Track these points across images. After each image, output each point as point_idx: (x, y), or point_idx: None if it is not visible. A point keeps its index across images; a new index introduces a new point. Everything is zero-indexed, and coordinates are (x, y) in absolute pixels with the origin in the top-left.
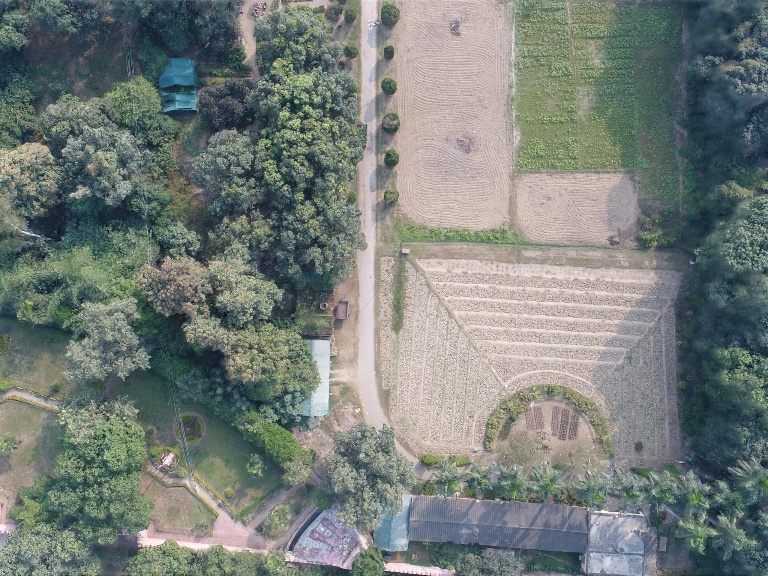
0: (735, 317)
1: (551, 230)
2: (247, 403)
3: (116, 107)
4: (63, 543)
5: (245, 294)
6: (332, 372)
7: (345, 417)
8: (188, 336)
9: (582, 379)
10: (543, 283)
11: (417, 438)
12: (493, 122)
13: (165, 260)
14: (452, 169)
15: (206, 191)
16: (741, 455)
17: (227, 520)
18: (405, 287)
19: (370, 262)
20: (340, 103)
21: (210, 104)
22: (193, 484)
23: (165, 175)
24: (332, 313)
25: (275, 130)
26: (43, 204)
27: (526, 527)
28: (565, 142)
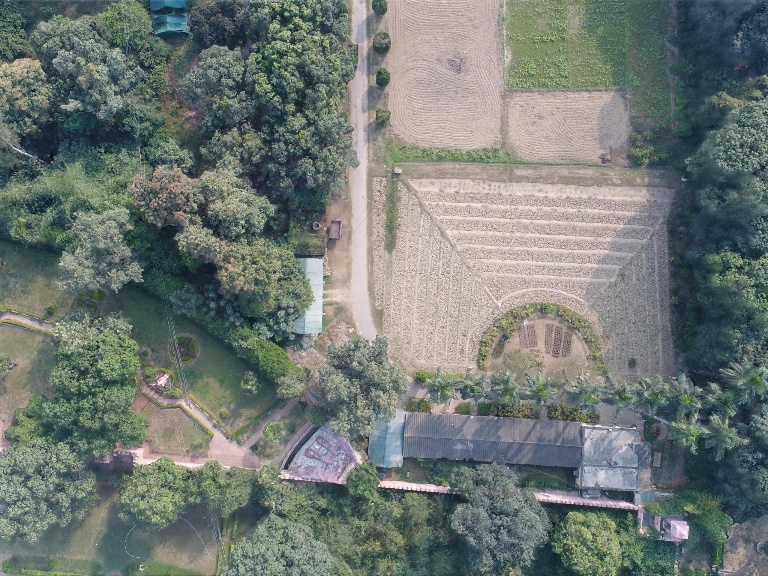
0: (726, 224)
1: (543, 149)
2: (241, 319)
3: (107, 27)
4: (58, 455)
5: (237, 204)
6: (325, 292)
7: (339, 337)
8: (180, 244)
9: (575, 297)
10: (535, 202)
11: (411, 357)
12: (484, 42)
13: (157, 169)
14: (443, 89)
15: (198, 113)
16: (733, 357)
17: (222, 440)
18: (398, 207)
19: (362, 182)
20: (330, 18)
21: (201, 22)
22: (187, 400)
23: (157, 97)
24: (325, 233)
25: (265, 43)
26: (35, 121)
27: (520, 442)
28: (556, 61)
